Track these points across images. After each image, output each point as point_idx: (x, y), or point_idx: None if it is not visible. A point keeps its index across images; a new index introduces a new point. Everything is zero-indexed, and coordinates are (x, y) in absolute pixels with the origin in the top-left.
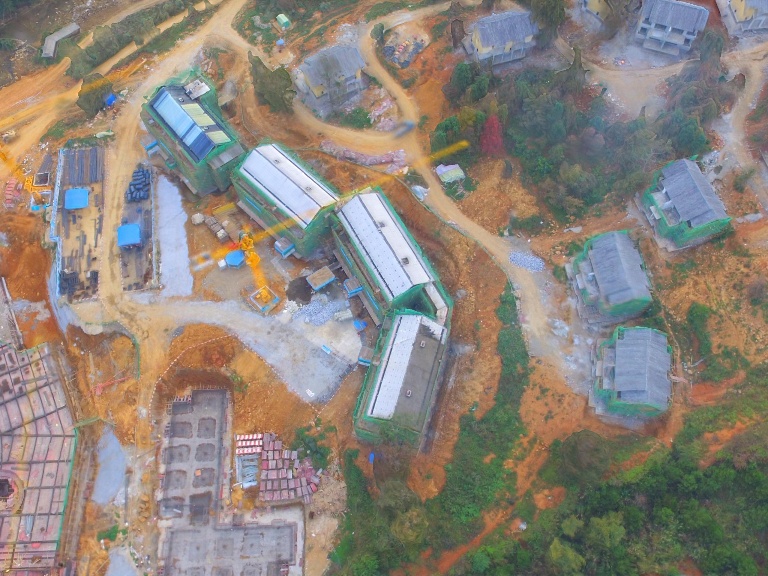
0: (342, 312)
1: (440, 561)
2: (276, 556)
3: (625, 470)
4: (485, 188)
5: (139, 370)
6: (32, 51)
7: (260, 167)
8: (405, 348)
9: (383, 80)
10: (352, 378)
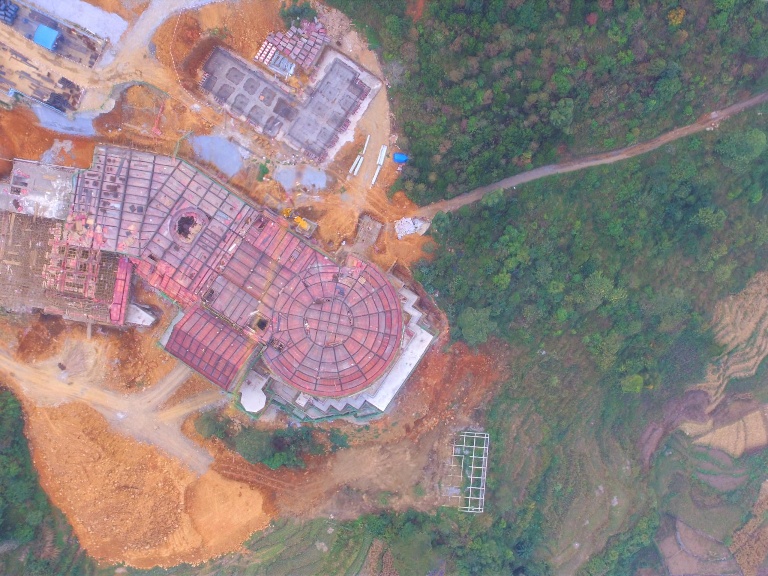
0: None
1: None
2: (347, 82)
3: None
4: None
5: (163, 92)
6: None
7: None
8: None
9: None
10: None
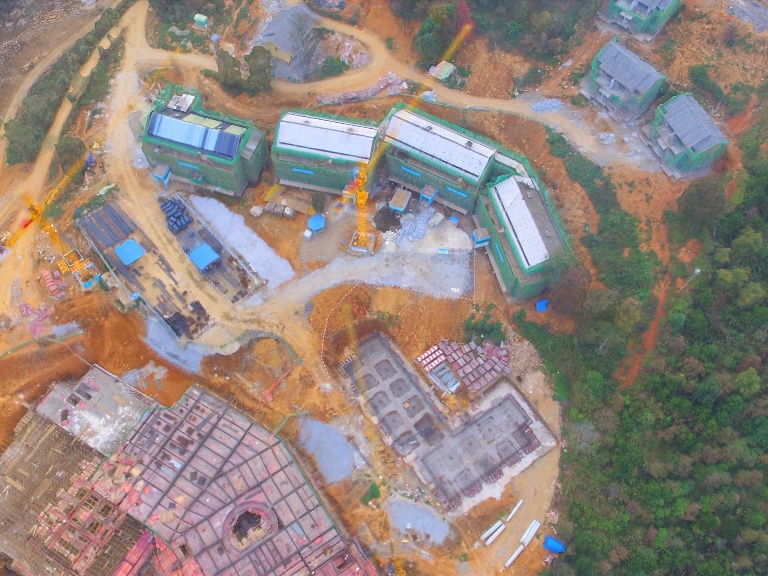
0: (434, 218)
1: (644, 343)
2: (514, 426)
3: (728, 199)
4: (480, 67)
5: (298, 356)
6: None
7: (295, 134)
8: (518, 205)
9: (331, 27)
10: (478, 262)
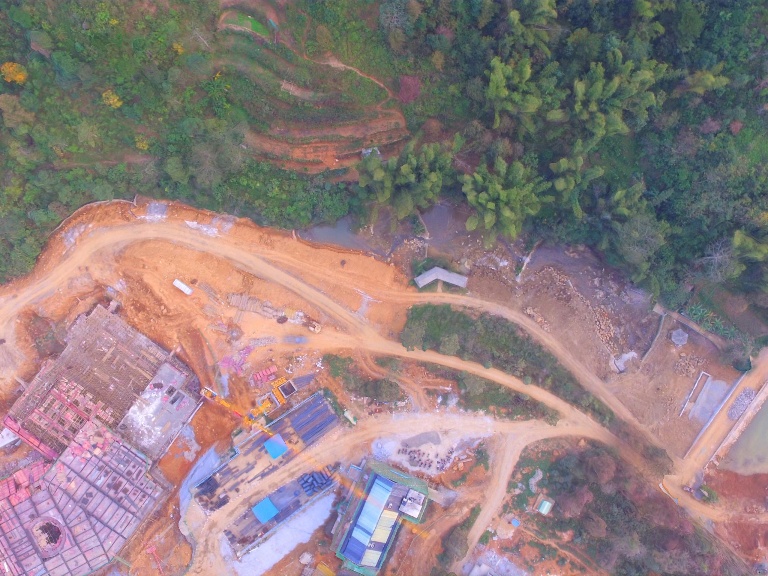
0: None
1: None
2: None
3: None
4: None
5: None
6: (422, 254)
7: None
8: None
9: None
10: None
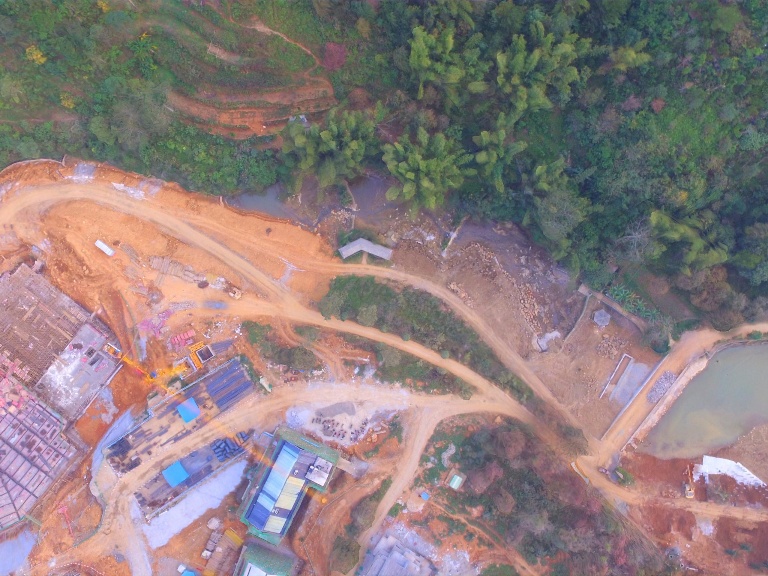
0: None
1: None
2: None
3: None
4: None
5: (80, 543)
6: (349, 226)
7: None
8: None
9: None
10: None
